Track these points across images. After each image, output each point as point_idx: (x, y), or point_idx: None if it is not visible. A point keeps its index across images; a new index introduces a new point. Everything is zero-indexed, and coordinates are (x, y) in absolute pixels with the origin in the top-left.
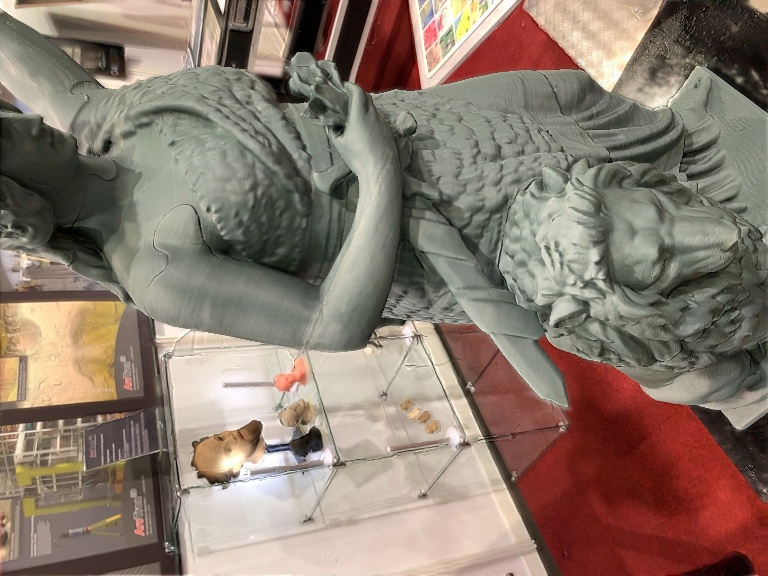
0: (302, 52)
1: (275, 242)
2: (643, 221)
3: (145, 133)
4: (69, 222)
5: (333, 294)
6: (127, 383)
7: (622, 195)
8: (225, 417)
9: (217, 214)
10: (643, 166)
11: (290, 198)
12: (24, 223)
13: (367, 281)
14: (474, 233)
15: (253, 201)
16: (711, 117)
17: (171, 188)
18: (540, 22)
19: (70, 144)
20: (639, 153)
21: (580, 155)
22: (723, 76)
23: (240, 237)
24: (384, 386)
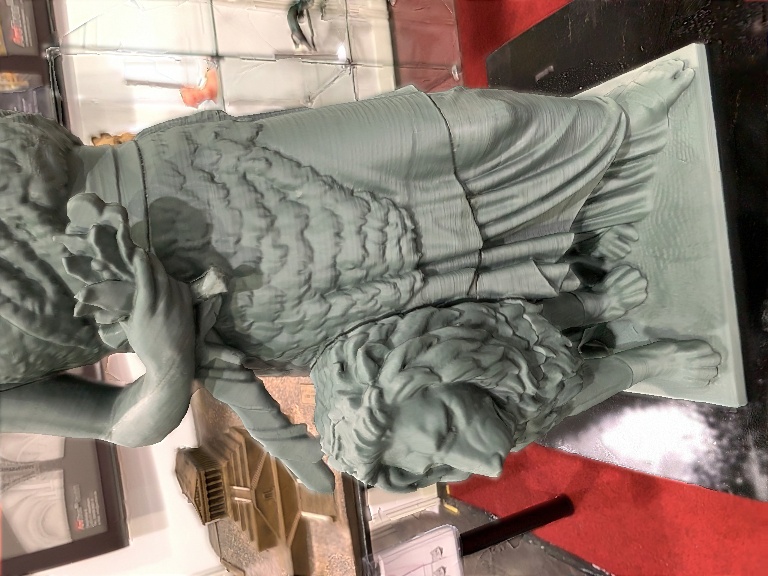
0: (81, 200)
1: (64, 364)
2: (420, 448)
3: None
4: None
5: (120, 429)
6: (17, 36)
7: (416, 414)
8: (133, 97)
9: None
10: (458, 372)
11: None
12: None
13: (152, 433)
14: (285, 360)
15: (24, 369)
16: (667, 122)
17: None
18: None
19: None
20: (530, 219)
21: (443, 255)
22: (713, 71)
23: (17, 382)
24: (314, 84)
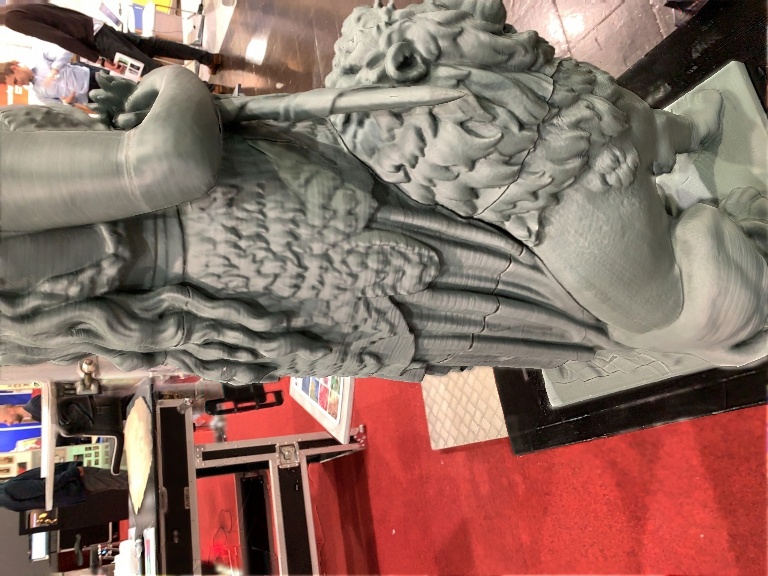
0: None
1: None
2: None
3: None
4: None
5: None
6: None
7: None
8: None
9: (4, 113)
10: None
11: (96, 130)
12: None
13: None
14: (304, 130)
15: (47, 110)
16: None
17: None
18: (451, 443)
19: None
20: None
21: None
22: None
23: None
24: None
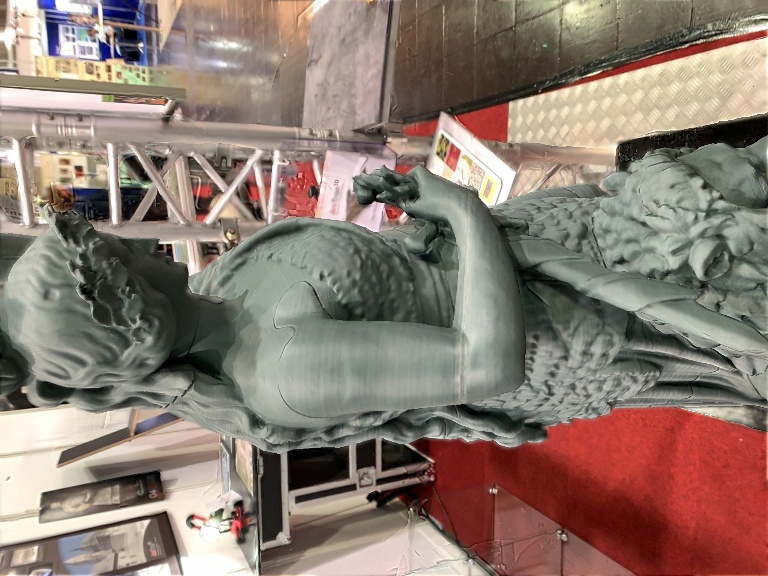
0: None
1: (390, 308)
2: (719, 154)
3: (242, 270)
4: (185, 348)
5: (468, 315)
6: None
7: None
8: None
9: (331, 276)
10: None
11: (391, 264)
12: (151, 316)
13: (497, 288)
14: None
15: (360, 261)
16: None
17: (280, 279)
18: None
19: (182, 265)
20: None
21: None
22: None
23: (357, 298)
24: None
